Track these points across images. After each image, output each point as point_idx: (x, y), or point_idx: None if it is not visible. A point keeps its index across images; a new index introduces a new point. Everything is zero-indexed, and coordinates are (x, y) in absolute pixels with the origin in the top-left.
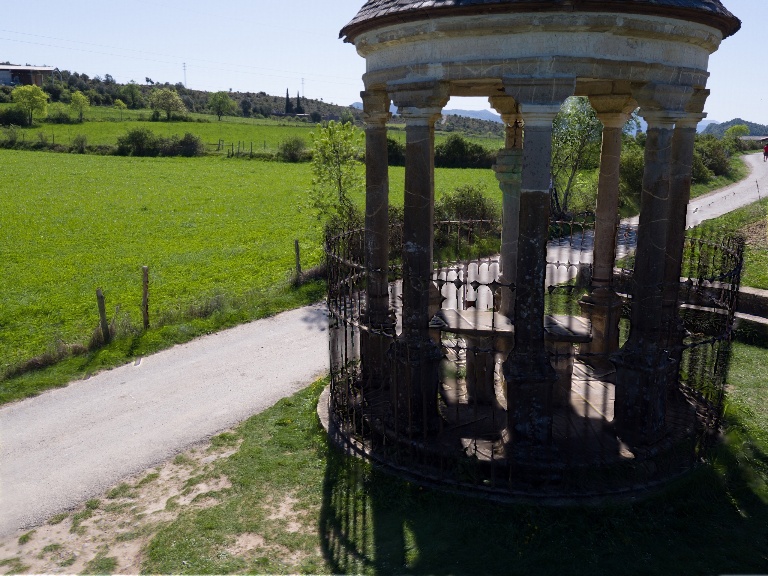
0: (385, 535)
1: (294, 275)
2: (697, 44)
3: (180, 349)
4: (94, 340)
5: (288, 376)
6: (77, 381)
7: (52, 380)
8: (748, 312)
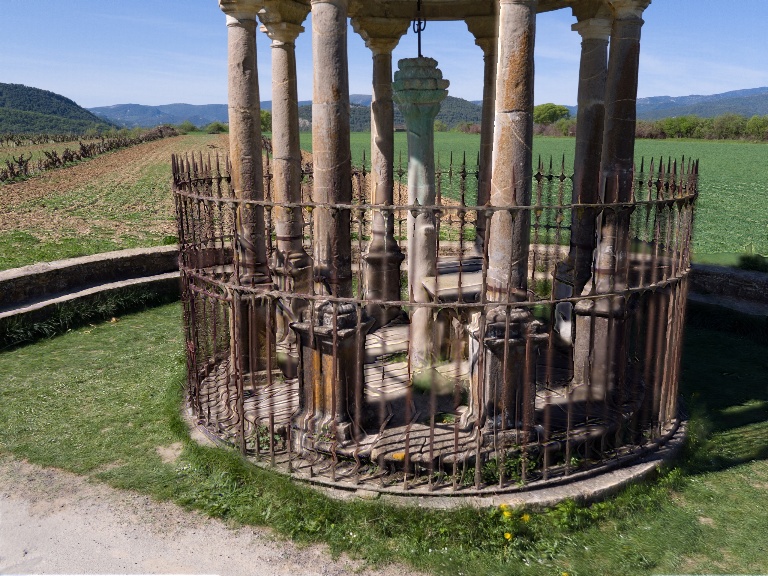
0: (749, 417)
1: None
2: None
3: None
4: None
5: None
6: None
7: None
8: (112, 281)
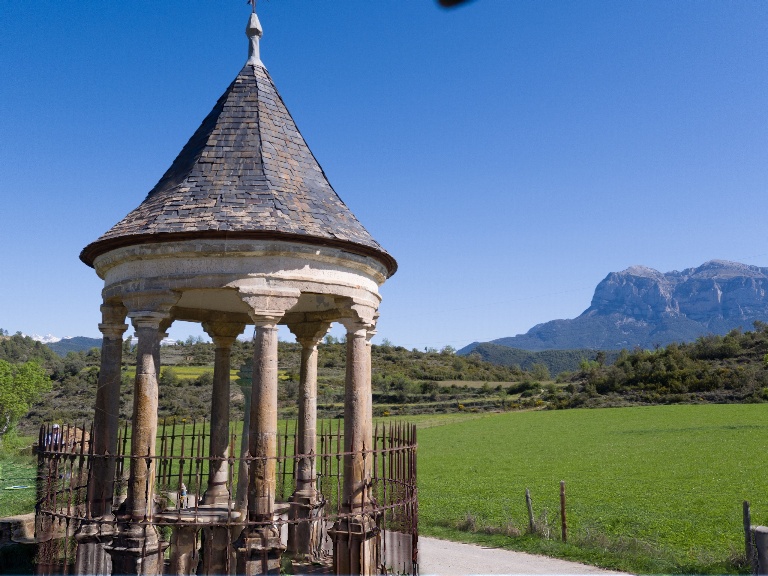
0: None
1: (732, 551)
2: (105, 272)
3: (513, 553)
4: (527, 532)
5: (412, 572)
6: (461, 542)
7: (461, 537)
8: None
